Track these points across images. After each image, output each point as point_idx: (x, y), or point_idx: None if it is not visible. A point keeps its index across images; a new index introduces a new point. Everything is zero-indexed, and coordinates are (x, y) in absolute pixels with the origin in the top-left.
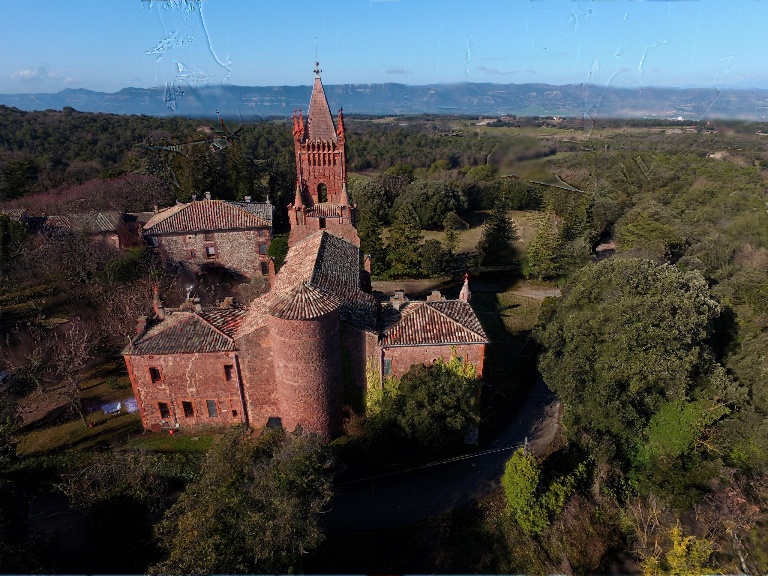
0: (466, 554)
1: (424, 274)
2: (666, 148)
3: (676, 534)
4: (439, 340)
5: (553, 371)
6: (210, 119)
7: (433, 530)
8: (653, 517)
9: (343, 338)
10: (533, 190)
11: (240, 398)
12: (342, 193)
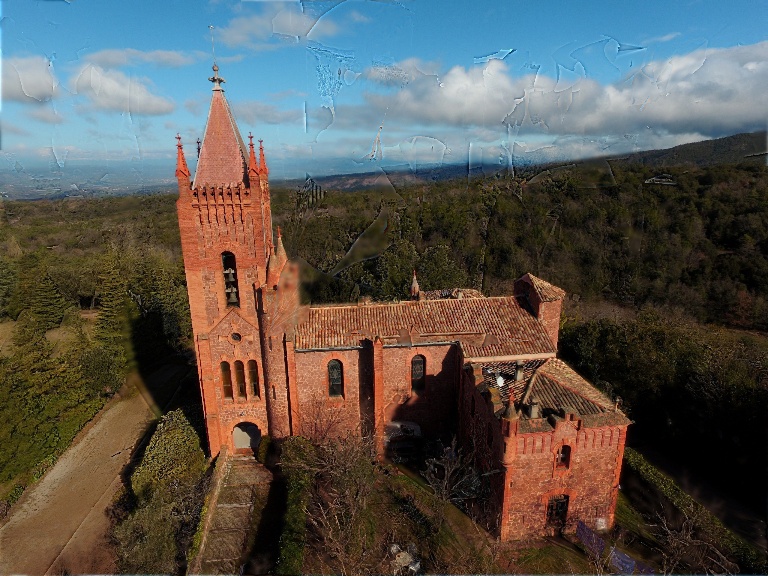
0: None
1: None
2: None
3: None
4: None
5: None
6: (350, 138)
7: None
8: None
9: None
10: None
11: None
12: (283, 251)
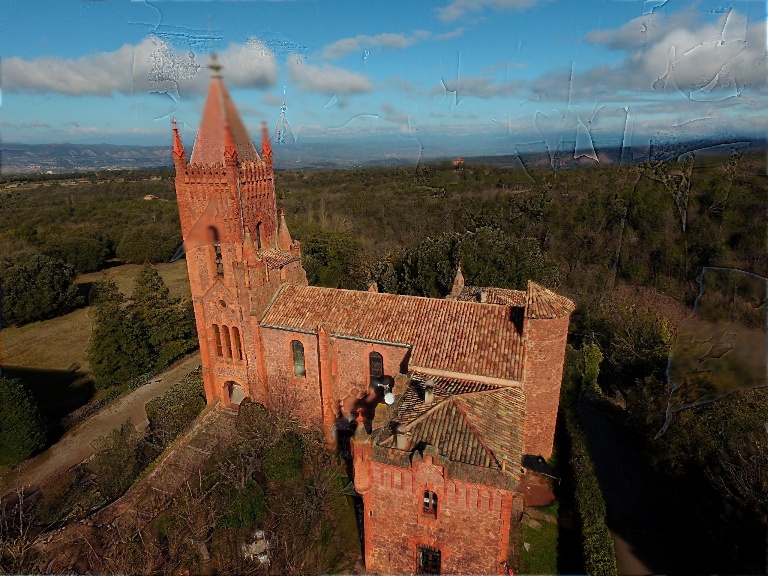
0: None
1: None
2: None
3: None
4: None
5: None
6: (240, 121)
7: None
8: None
9: None
10: None
11: None
12: (284, 230)
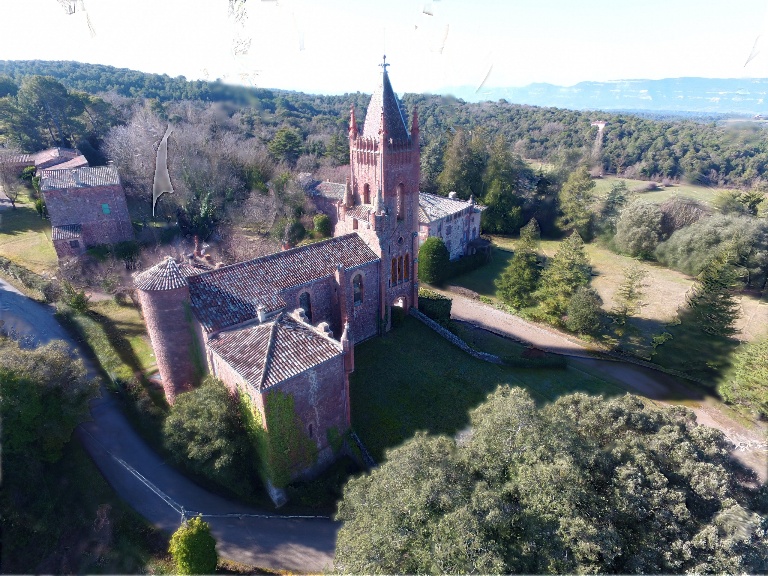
0: (122, 568)
1: (570, 329)
2: None
3: None
4: (236, 365)
5: None
6: None
7: None
8: None
9: (193, 322)
10: None
11: None
12: (375, 197)
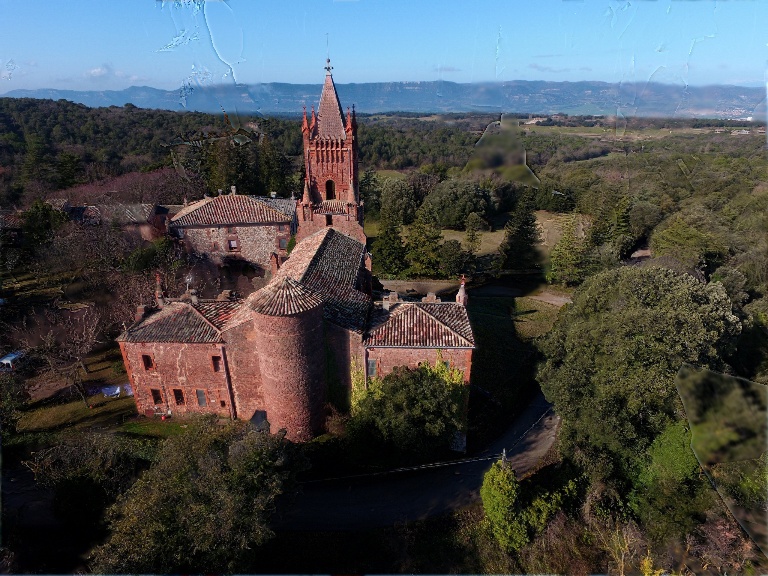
0: (434, 564)
1: (442, 275)
2: (715, 150)
3: (647, 566)
4: (424, 343)
5: (550, 381)
6: (217, 115)
7: (400, 537)
8: (631, 545)
9: (327, 336)
10: None
11: (227, 389)
12: (349, 190)
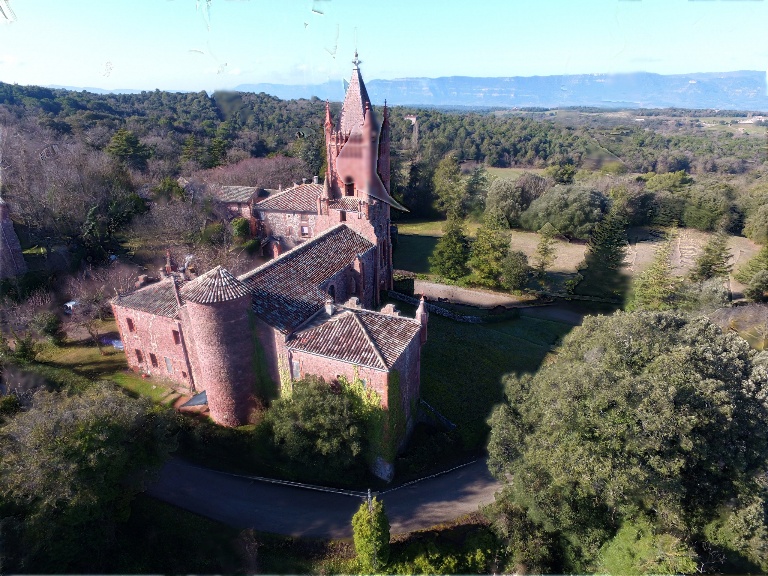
0: None
1: (504, 287)
2: None
3: None
4: (341, 355)
5: None
6: None
7: None
8: None
9: (256, 330)
10: (660, 208)
11: (185, 362)
12: None
